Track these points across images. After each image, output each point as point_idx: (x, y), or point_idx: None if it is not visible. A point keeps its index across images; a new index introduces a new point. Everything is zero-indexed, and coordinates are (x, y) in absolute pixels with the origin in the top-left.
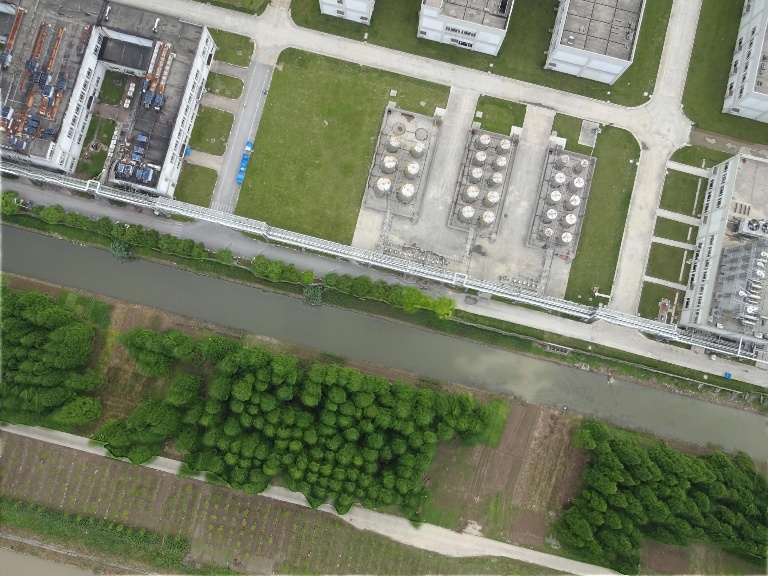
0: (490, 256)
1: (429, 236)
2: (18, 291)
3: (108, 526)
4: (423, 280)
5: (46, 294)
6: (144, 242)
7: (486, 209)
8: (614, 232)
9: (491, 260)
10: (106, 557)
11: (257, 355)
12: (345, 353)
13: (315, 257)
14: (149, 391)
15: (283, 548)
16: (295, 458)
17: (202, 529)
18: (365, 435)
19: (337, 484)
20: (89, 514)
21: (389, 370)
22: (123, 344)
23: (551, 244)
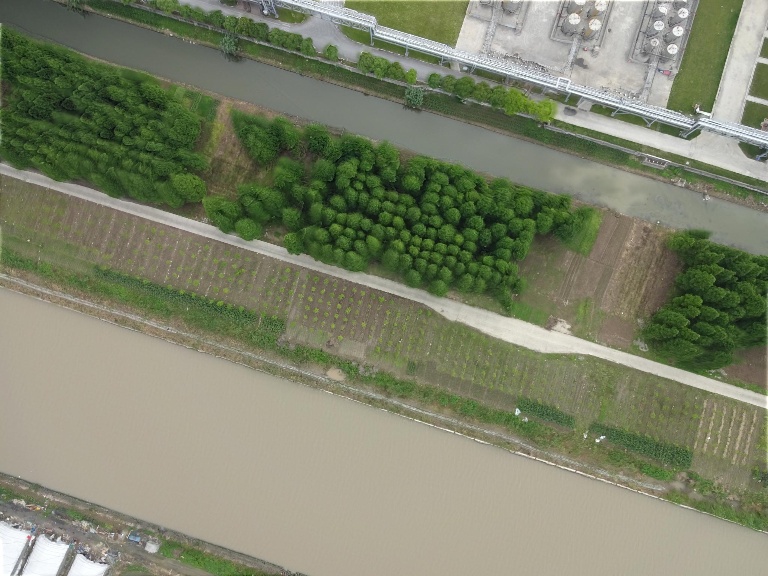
0: (592, 69)
1: (531, 47)
2: (130, 81)
3: (209, 302)
4: (526, 84)
5: (156, 86)
6: (255, 32)
7: (592, 17)
8: (719, 51)
9: (592, 73)
10: (204, 335)
11: (360, 146)
12: (442, 156)
13: (418, 62)
14: (251, 183)
15: (375, 334)
16: (398, 231)
17: (298, 311)
18: (466, 219)
19: (439, 256)
20: (191, 291)
21: (486, 174)
22: (227, 137)
23: (655, 57)
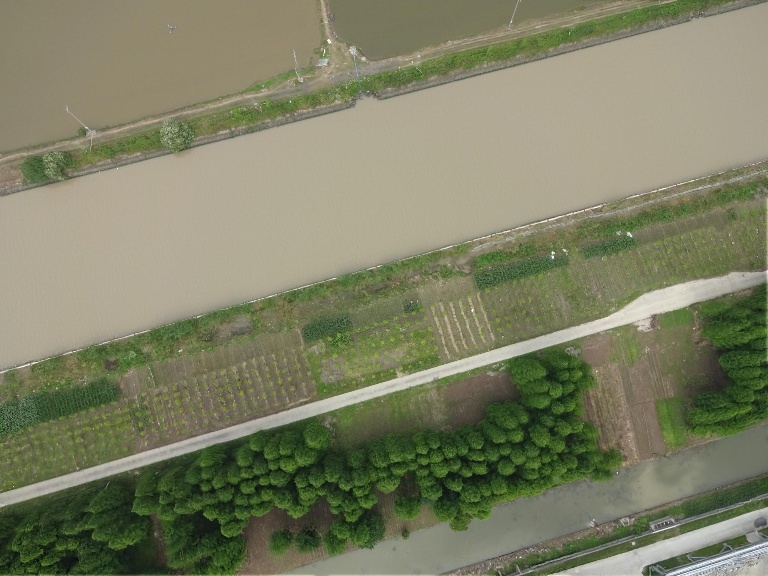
0: None
1: None
2: None
3: None
4: None
5: None
6: None
7: None
8: None
9: (767, 574)
10: None
11: None
12: None
13: None
14: None
15: None
16: None
17: None
18: None
19: None
20: None
21: None
22: None
23: None
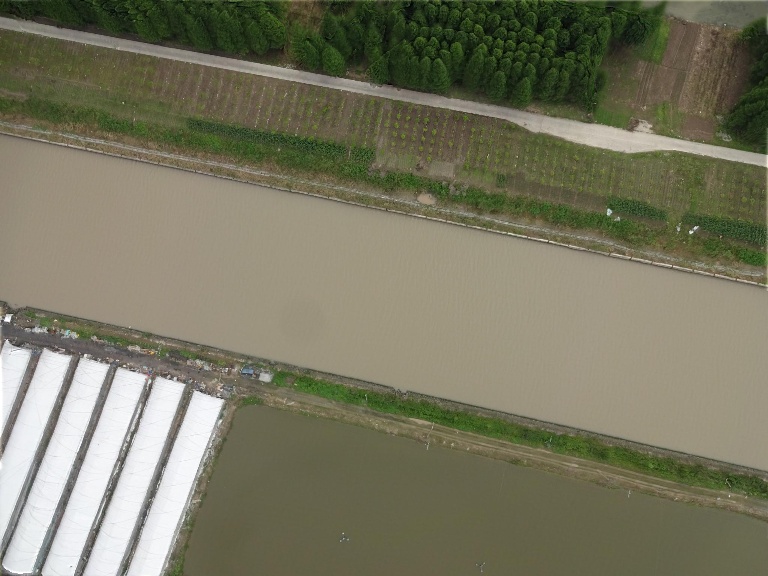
0: None
1: None
2: None
3: (300, 139)
4: None
5: None
6: None
7: None
8: None
9: None
10: (296, 174)
11: None
12: None
13: None
14: (327, 31)
15: (462, 153)
16: None
17: (385, 140)
18: (542, 24)
19: None
20: (281, 132)
21: None
22: None
23: None
